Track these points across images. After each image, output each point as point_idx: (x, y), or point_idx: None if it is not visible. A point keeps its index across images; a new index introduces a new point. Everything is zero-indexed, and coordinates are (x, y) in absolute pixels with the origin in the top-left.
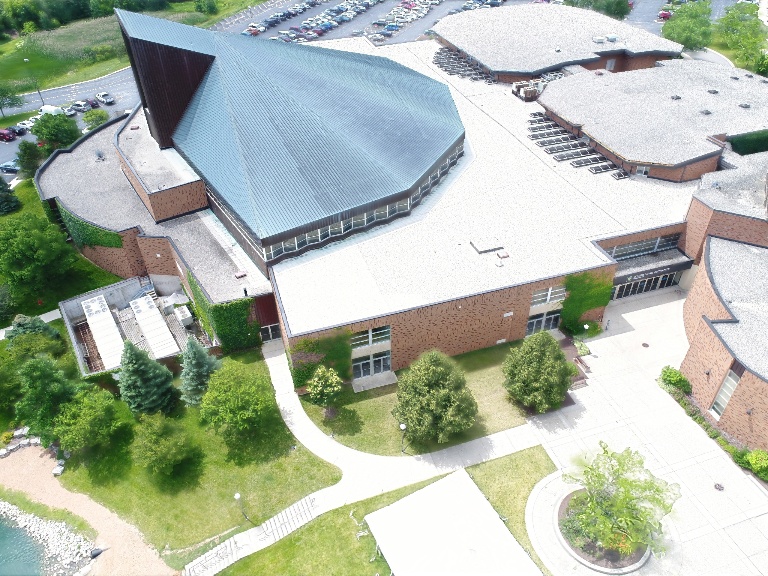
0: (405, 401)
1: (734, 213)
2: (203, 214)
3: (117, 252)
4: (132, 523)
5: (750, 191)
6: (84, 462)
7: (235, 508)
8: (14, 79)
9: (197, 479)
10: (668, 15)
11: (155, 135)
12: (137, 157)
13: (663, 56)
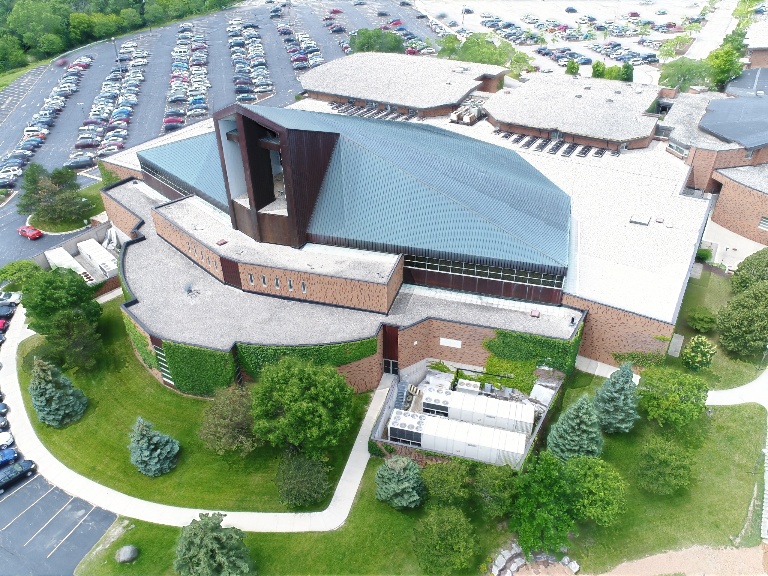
0: (760, 328)
1: (728, 149)
2: (408, 290)
3: (365, 363)
4: (690, 545)
5: (704, 137)
6: (587, 542)
7: (738, 474)
8: None
9: (690, 477)
10: (412, 51)
11: (280, 237)
12: (290, 264)
13: (502, 75)
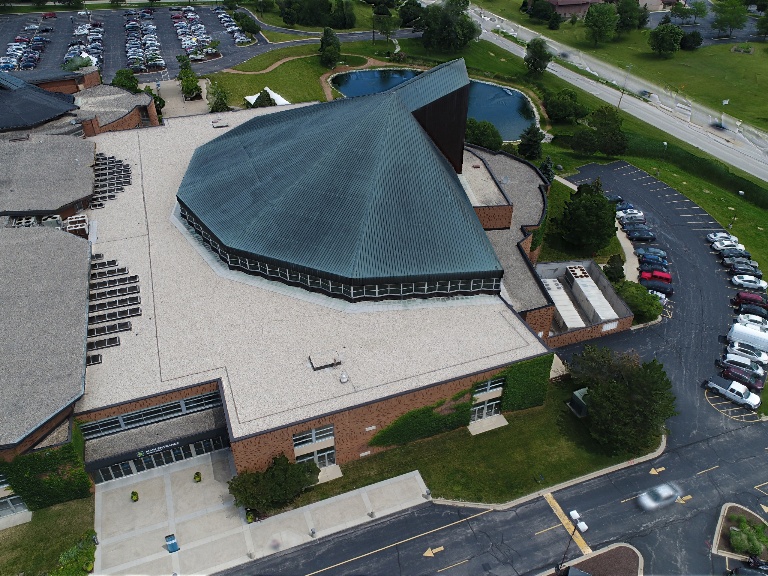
0: None
1: None
2: None
3: None
4: None
5: (54, 125)
6: None
7: None
8: None
9: None
10: None
11: None
12: None
13: None
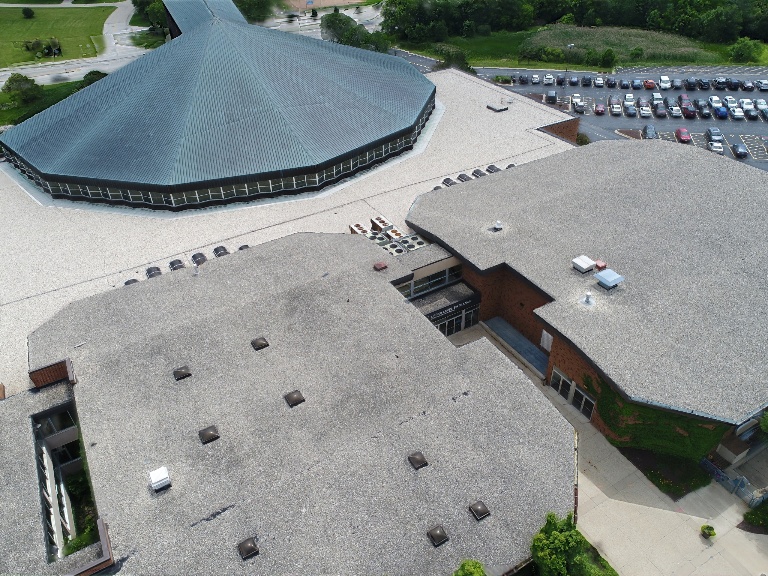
0: None
1: None
2: None
3: None
4: None
5: None
6: None
7: None
8: (460, 48)
9: None
10: None
11: None
12: None
13: None
